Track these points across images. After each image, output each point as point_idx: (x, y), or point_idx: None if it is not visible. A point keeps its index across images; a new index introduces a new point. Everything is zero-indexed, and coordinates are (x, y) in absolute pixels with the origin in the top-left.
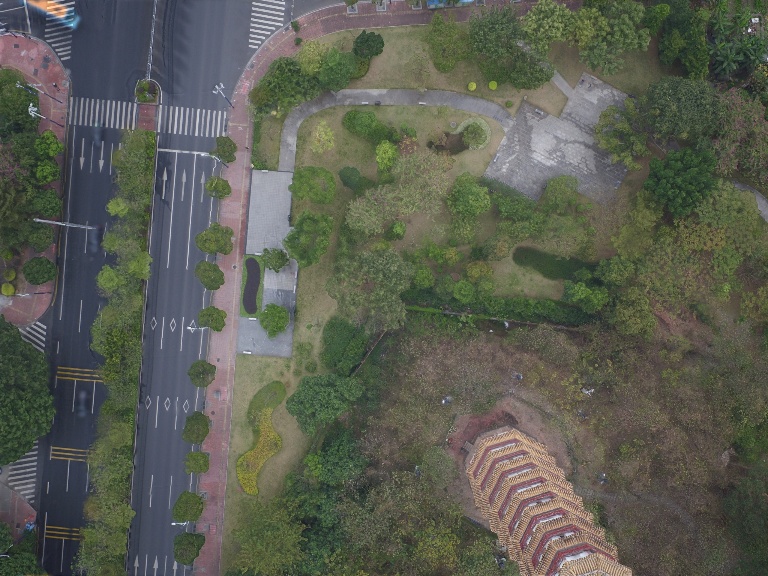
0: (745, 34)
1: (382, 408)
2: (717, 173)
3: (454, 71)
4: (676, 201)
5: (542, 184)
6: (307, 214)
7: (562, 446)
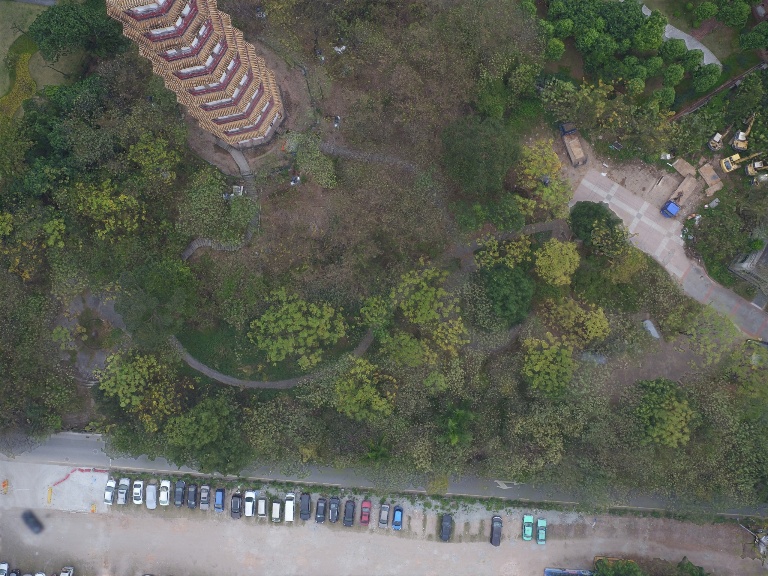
0: None
1: (131, 48)
2: None
3: None
4: None
5: None
6: None
7: (306, 96)
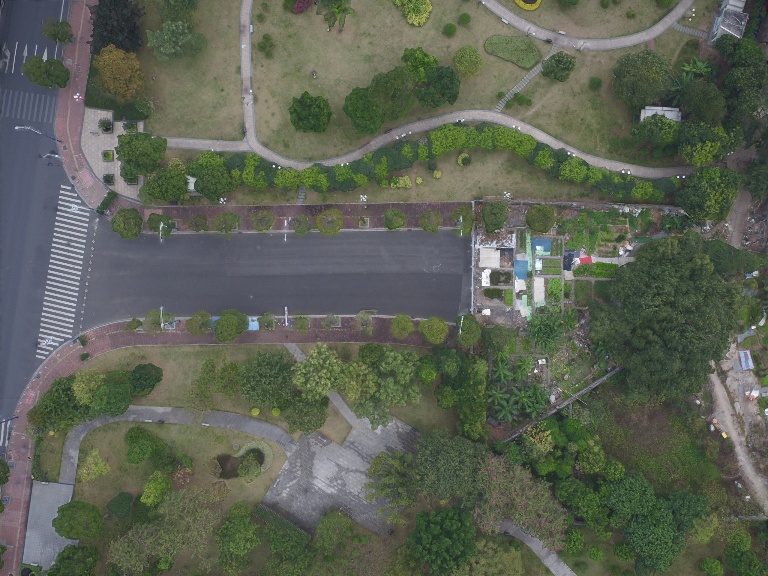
0: (531, 375)
1: None
2: (482, 531)
3: (239, 394)
4: (432, 567)
5: (321, 511)
6: (66, 554)
7: None
